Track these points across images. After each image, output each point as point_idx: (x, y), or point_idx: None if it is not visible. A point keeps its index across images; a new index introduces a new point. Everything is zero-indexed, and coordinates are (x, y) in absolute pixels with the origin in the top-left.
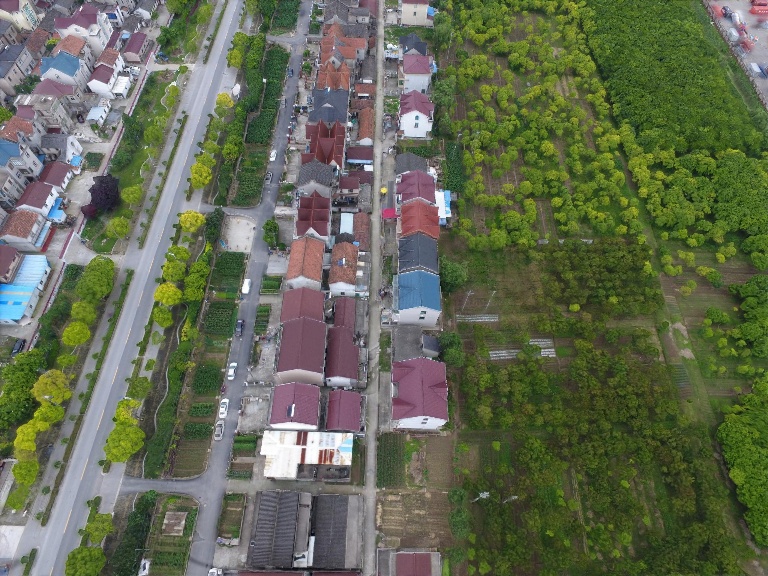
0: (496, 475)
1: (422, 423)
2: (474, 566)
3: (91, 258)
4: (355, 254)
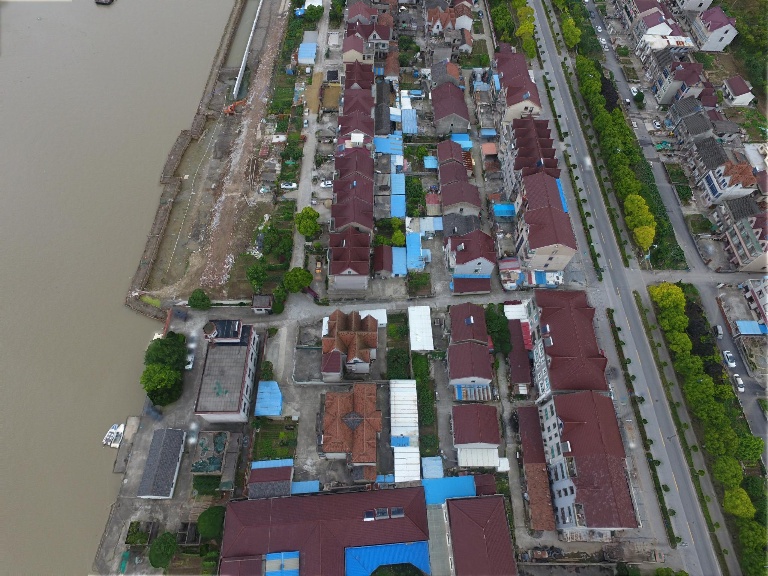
0: (764, 61)
1: (719, 41)
2: (767, 85)
3: None
4: None
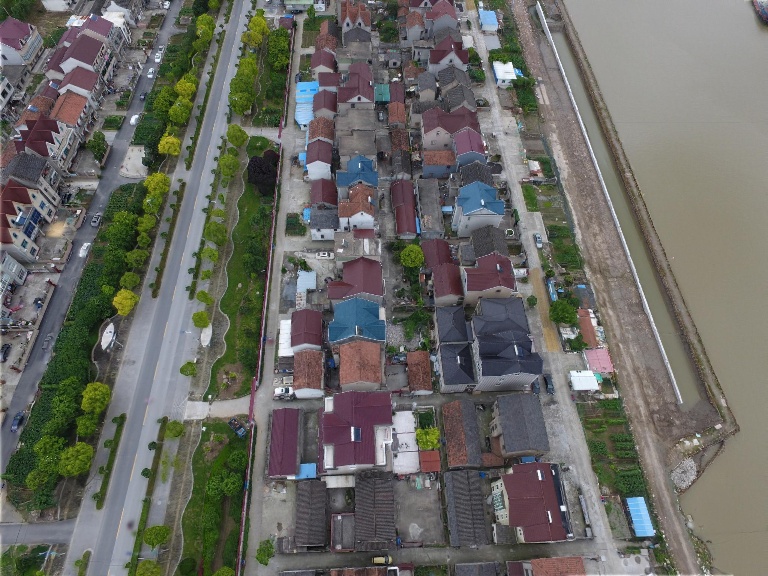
0: None
1: None
2: None
3: (267, 133)
4: (19, 120)
